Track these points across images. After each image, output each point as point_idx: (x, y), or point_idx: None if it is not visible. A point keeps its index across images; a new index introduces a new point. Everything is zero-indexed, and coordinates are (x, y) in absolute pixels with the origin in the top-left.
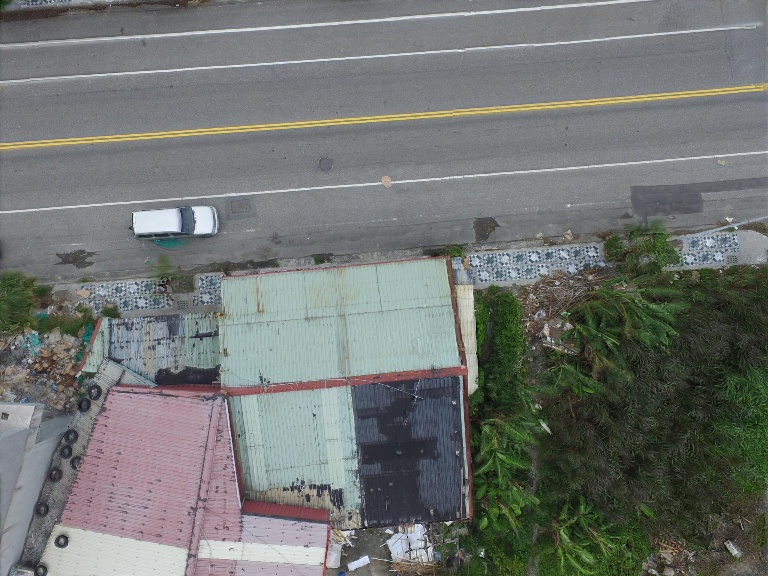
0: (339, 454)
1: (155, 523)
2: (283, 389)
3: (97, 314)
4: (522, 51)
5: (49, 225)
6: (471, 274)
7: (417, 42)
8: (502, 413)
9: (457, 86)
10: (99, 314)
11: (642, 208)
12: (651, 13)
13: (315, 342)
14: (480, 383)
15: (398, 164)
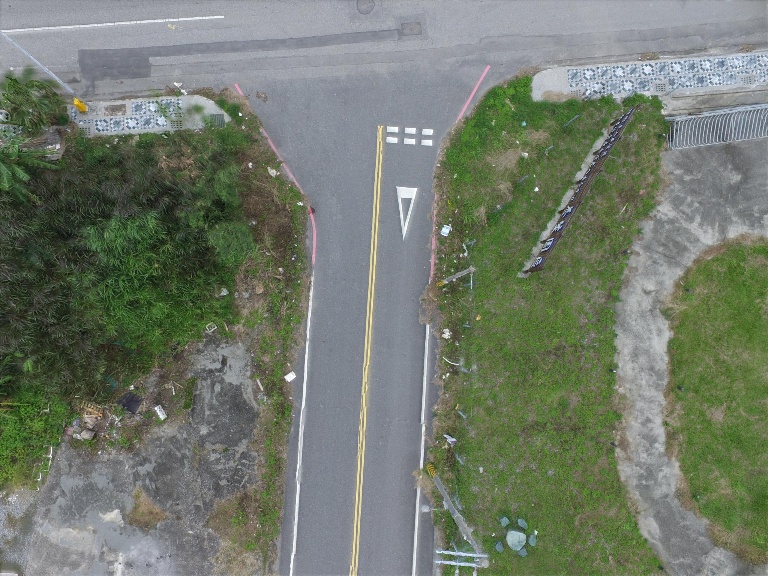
0: None
1: None
2: None
3: None
4: None
5: None
6: None
7: None
8: None
9: None
10: None
11: (90, 72)
12: None
13: None
14: None
15: None
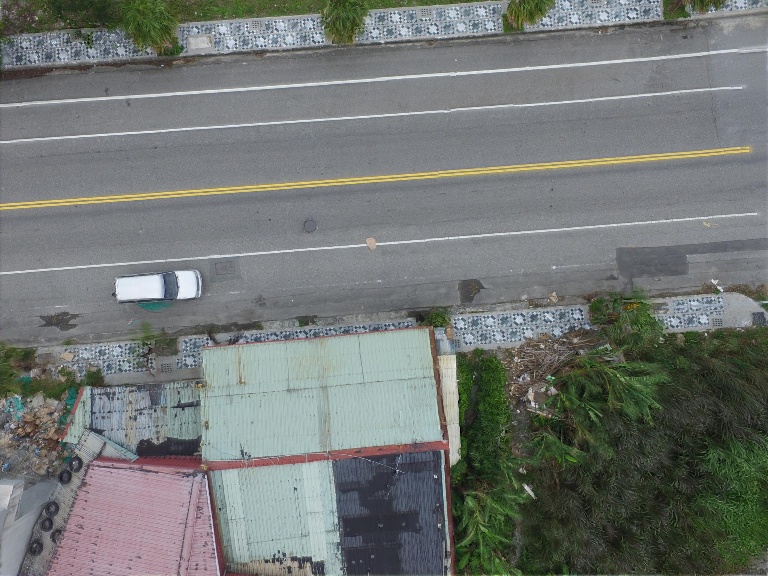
0: (320, 527)
1: None
2: (264, 463)
3: (80, 377)
4: (508, 112)
5: (33, 287)
6: (456, 337)
7: (402, 103)
8: (485, 482)
9: (442, 147)
10: (82, 377)
11: (627, 270)
12: (637, 73)
13: (297, 414)
14: (462, 454)
15: (383, 226)
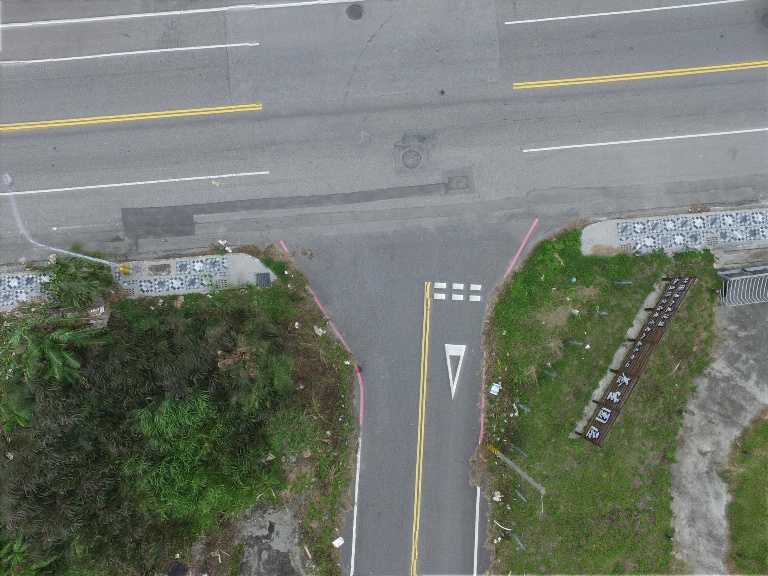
0: None
1: None
2: None
3: None
4: (12, 68)
5: None
6: None
7: None
8: None
9: None
10: None
11: (134, 231)
12: (150, 29)
13: None
14: None
15: None
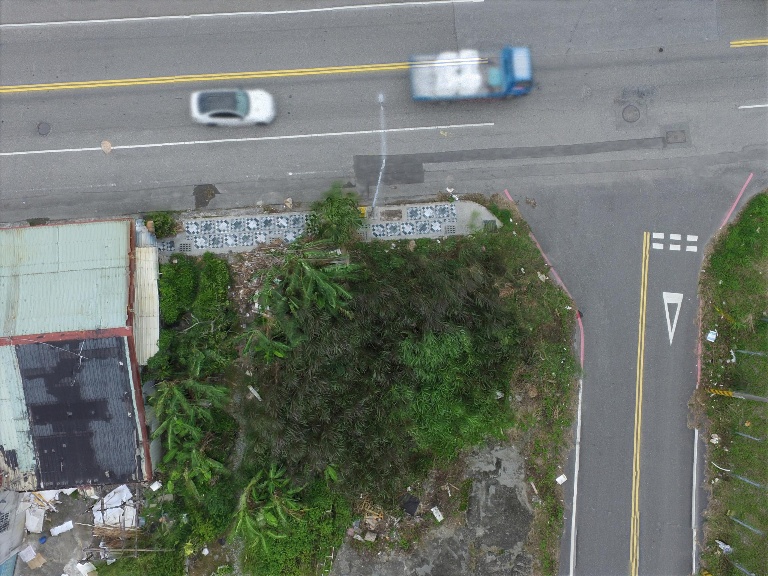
0: (9, 415)
1: None
2: None
3: None
4: (249, 19)
5: None
6: (187, 240)
7: (142, 8)
8: (192, 377)
9: (181, 52)
10: None
11: (365, 178)
12: None
13: None
14: (161, 345)
15: (118, 129)
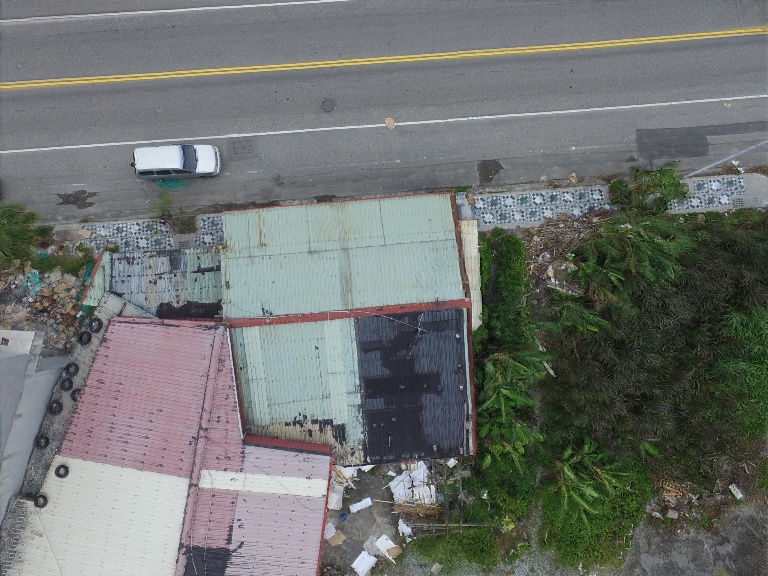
0: (342, 388)
1: (156, 453)
2: (285, 321)
3: (98, 254)
4: None
5: (50, 165)
6: None
7: None
8: (506, 351)
9: (461, 28)
10: None
11: (647, 151)
12: None
13: (318, 275)
14: (484, 319)
15: (402, 106)
